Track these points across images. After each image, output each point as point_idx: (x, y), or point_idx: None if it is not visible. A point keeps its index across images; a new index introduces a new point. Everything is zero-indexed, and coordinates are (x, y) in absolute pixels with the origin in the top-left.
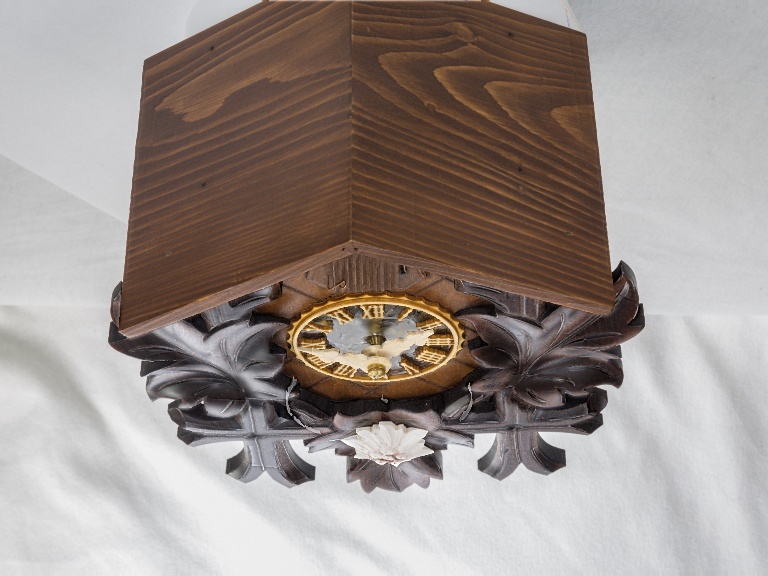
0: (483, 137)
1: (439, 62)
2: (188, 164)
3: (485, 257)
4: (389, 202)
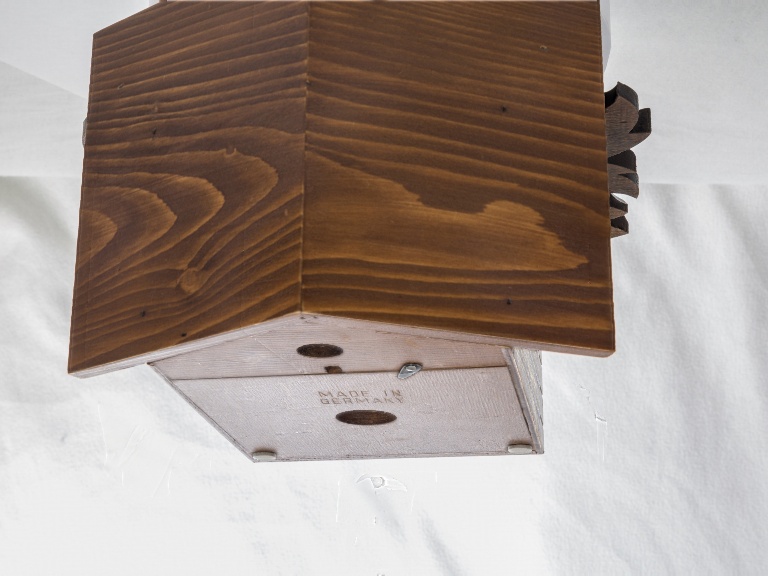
0: (184, 147)
1: (218, 218)
2: (529, 149)
3: (196, 3)
4: (276, 2)
